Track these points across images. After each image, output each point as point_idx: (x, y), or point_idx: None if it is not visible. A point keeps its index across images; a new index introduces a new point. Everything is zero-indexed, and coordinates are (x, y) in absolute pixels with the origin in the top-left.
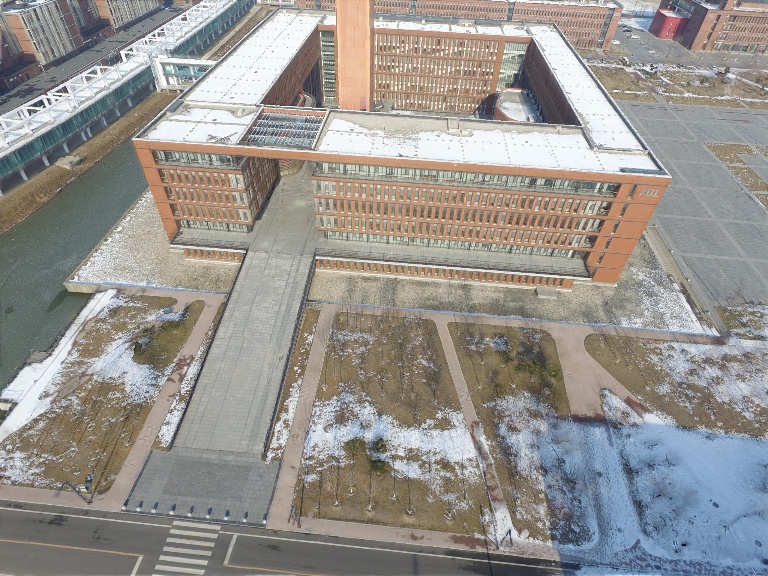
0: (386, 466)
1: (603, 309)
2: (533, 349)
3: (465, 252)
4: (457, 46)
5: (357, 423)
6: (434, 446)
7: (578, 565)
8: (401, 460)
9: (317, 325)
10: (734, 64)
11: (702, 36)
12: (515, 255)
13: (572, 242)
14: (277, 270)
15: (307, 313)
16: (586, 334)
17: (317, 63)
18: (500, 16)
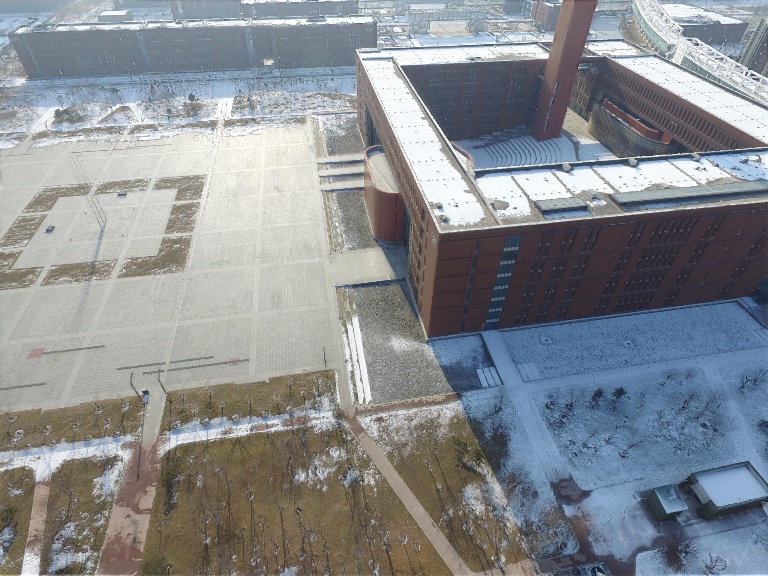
0: None
1: None
2: None
3: None
4: None
5: None
6: None
7: None
8: None
9: None
10: None
11: None
12: None
13: None
14: None
15: None
16: None
17: None
18: None
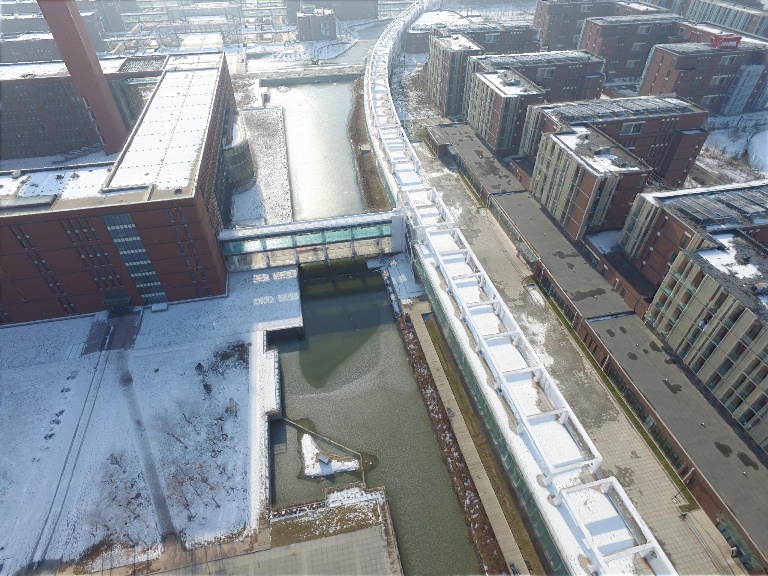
0: None
1: None
2: None
3: None
4: None
5: None
6: None
7: None
8: None
9: None
10: None
11: None
12: None
13: None
14: None
15: None
16: None
17: None
18: None
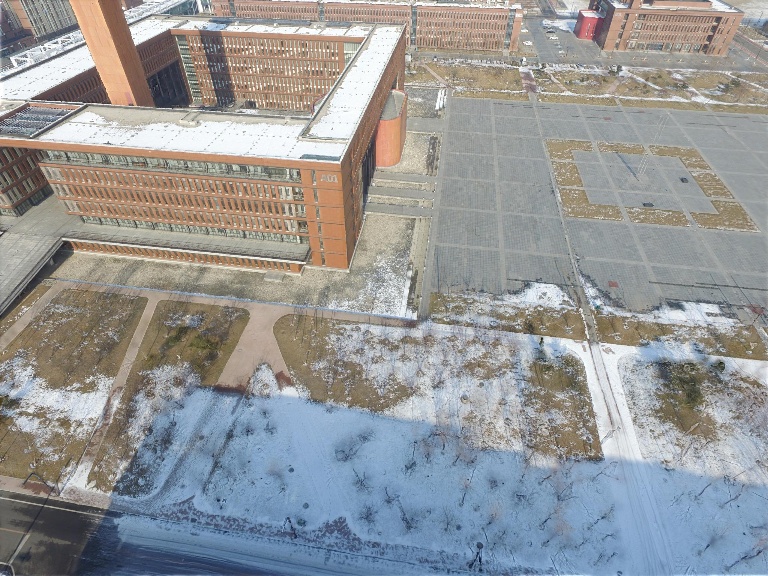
0: (8, 420)
1: (320, 292)
2: (223, 326)
3: (203, 236)
4: (300, 47)
5: (9, 383)
6: (65, 406)
7: (121, 514)
8: (27, 416)
9: (39, 299)
10: (641, 63)
11: (613, 35)
12: (248, 240)
13: (288, 227)
14: (20, 249)
15: (38, 289)
16: (284, 314)
17: (174, 65)
18: (405, 19)
